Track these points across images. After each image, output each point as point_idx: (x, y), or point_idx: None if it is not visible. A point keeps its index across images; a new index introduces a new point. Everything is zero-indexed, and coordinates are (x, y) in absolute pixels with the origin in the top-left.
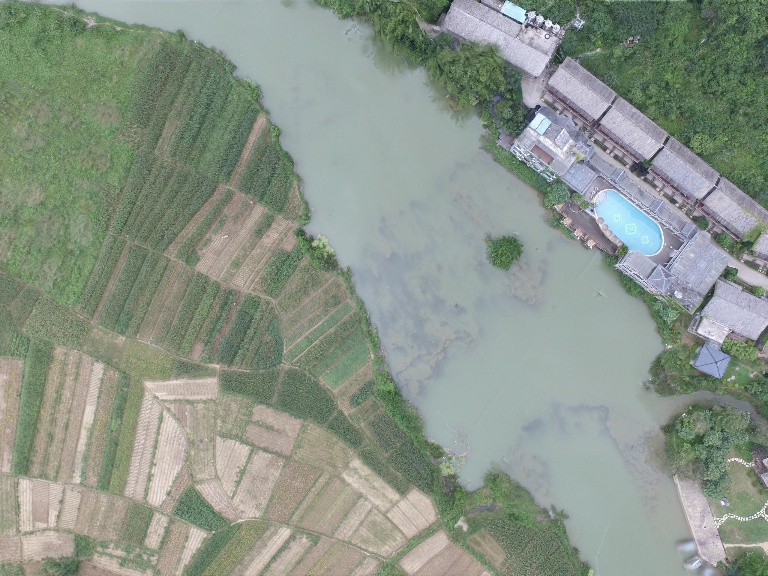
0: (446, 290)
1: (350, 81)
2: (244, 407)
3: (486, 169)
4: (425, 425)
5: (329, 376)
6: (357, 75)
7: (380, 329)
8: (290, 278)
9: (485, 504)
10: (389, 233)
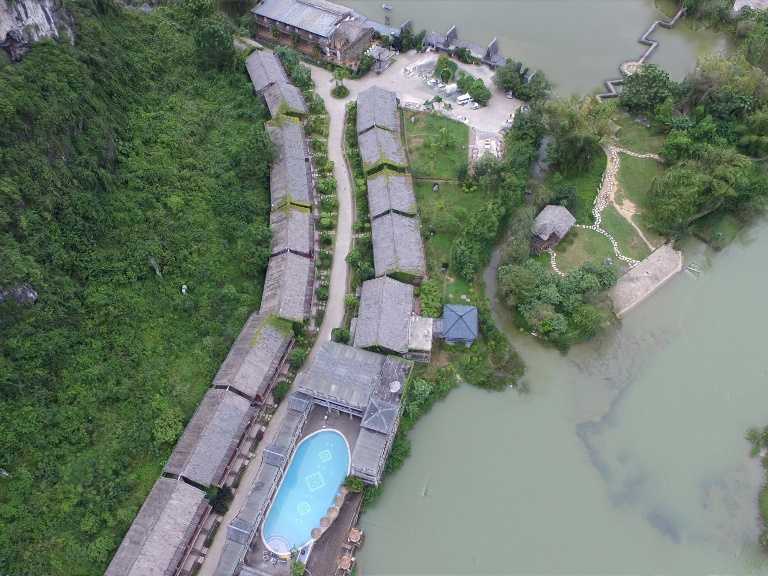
0: None
1: None
2: None
3: None
4: None
5: None
6: None
7: None
8: None
9: None
10: None
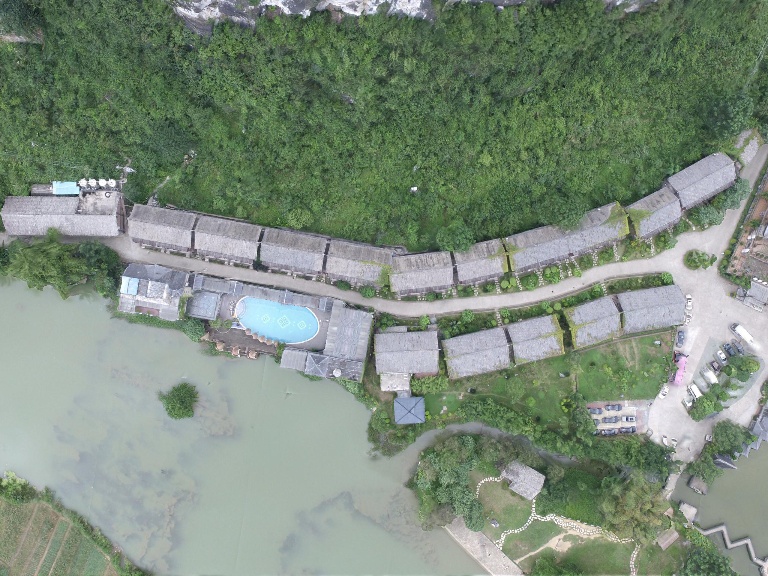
0: (147, 462)
1: None
2: None
3: (127, 334)
4: None
5: None
6: None
7: (104, 529)
8: None
9: None
10: (68, 438)
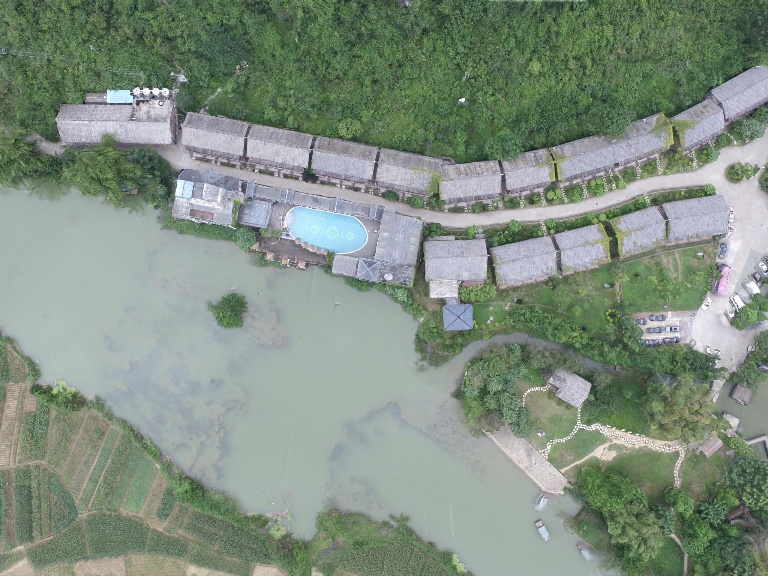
0: (196, 372)
1: (15, 228)
2: (64, 572)
3: (177, 245)
4: (238, 503)
5: (128, 504)
6: (20, 219)
7: (154, 437)
8: (48, 434)
9: (327, 546)
10: (118, 347)
